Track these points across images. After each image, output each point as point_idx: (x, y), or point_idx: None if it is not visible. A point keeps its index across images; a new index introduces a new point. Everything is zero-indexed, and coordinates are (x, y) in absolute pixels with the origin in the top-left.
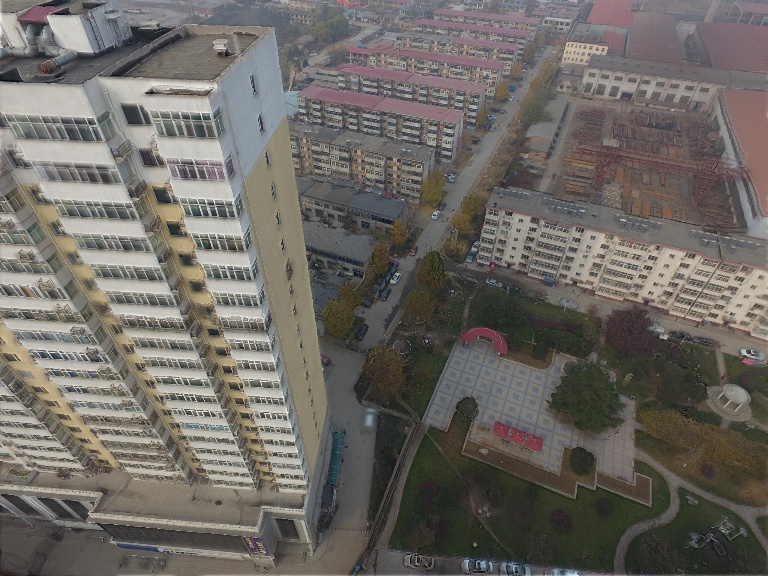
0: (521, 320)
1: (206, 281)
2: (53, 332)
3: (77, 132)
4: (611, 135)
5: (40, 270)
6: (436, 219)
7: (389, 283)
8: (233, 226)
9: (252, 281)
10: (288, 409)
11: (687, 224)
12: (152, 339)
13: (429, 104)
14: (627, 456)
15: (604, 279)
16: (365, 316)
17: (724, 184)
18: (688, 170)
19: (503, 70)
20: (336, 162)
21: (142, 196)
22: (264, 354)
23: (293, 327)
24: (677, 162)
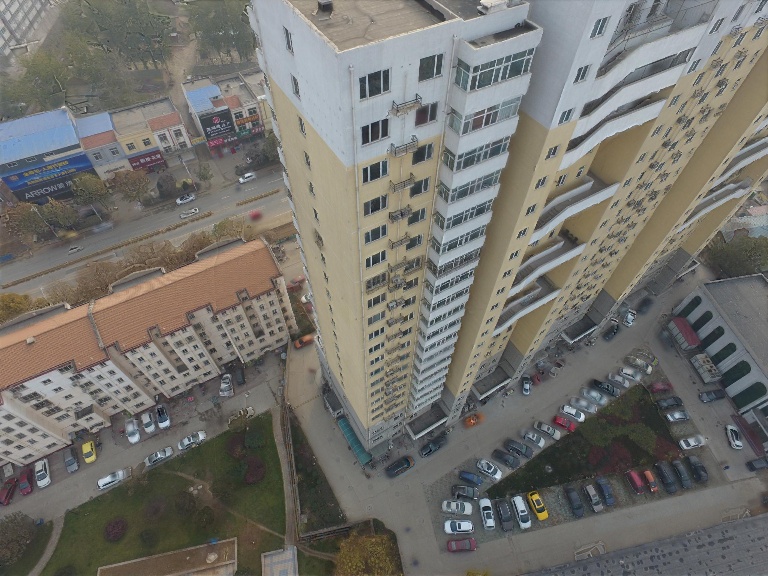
0: None
1: None
2: None
3: None
4: None
5: None
6: None
7: None
8: None
9: None
10: None
11: None
12: None
13: None
14: None
15: None
16: None
17: None
18: None
19: None
20: None
21: None
22: None
23: None
24: None
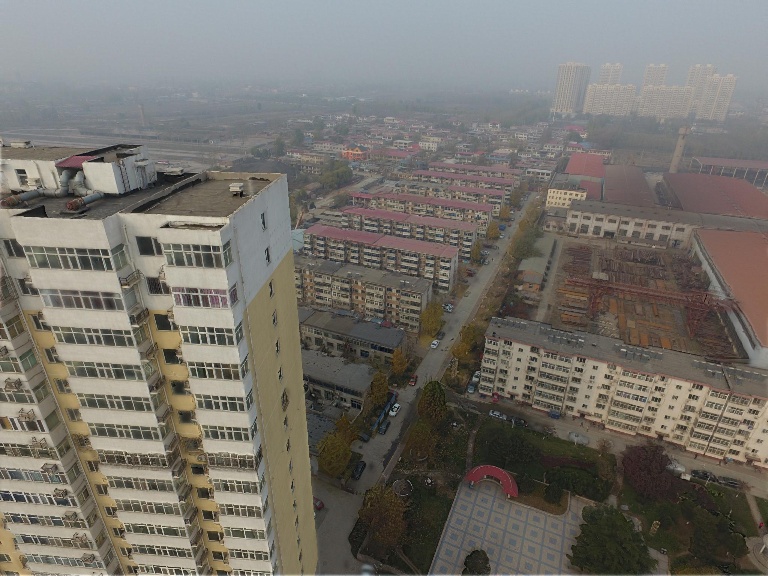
0: (530, 457)
1: (196, 412)
2: (22, 470)
3: (89, 262)
4: (599, 269)
5: (23, 400)
6: (435, 348)
7: (388, 415)
8: (231, 354)
9: (245, 413)
10: (273, 566)
11: (688, 354)
12: (129, 478)
13: (426, 241)
14: None
15: (612, 411)
16: (362, 451)
17: (716, 315)
18: (679, 302)
19: (493, 212)
20: (337, 292)
21: (143, 324)
22: (251, 497)
23: (285, 465)
24: (667, 294)
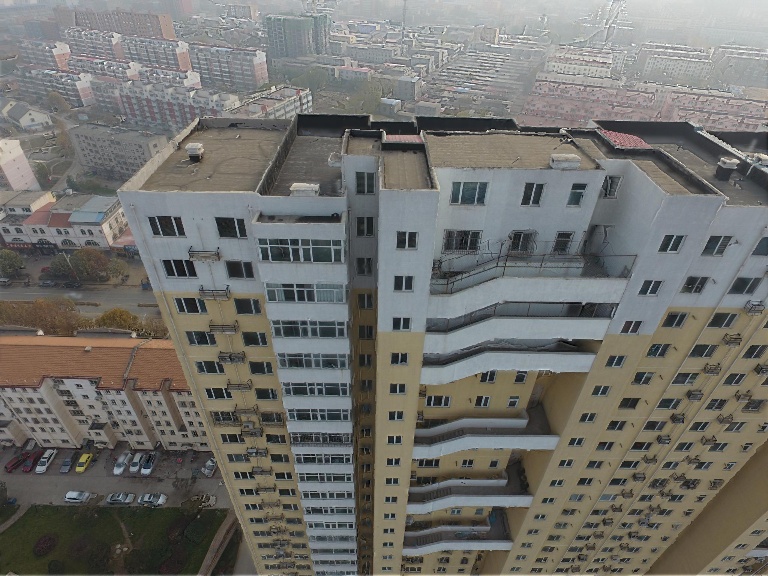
0: None
1: None
2: None
3: None
4: None
5: None
6: None
7: None
8: None
9: None
10: None
11: None
12: None
13: None
14: None
15: None
16: None
17: None
18: None
19: None
20: None
21: None
22: None
23: None
24: None
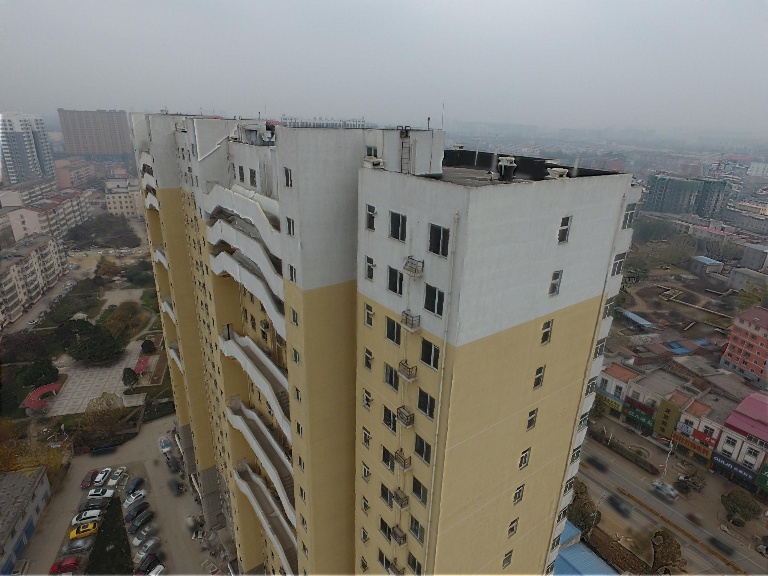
0: (11, 388)
1: None
2: None
3: None
4: None
5: None
6: None
7: None
8: None
9: None
10: None
11: None
12: None
13: None
14: (135, 343)
15: None
16: None
17: None
18: None
19: None
20: None
21: None
22: None
23: None
24: None
